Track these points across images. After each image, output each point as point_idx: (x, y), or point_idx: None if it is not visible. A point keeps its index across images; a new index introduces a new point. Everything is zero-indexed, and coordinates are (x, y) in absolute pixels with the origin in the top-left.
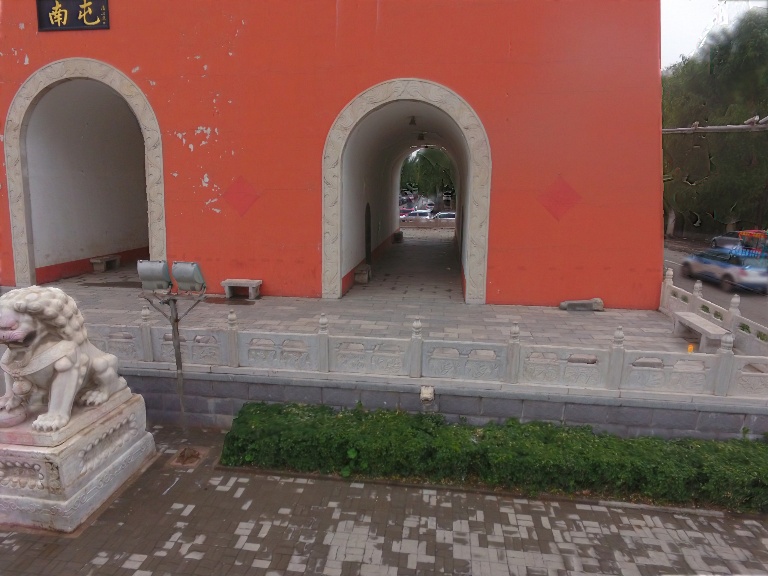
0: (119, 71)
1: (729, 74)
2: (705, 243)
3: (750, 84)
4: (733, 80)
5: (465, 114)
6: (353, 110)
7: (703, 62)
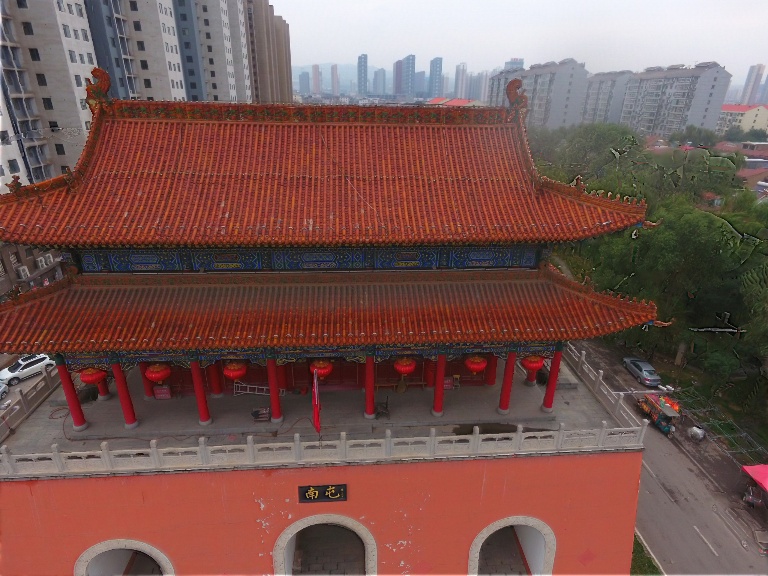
0: (352, 519)
1: (645, 270)
2: (617, 350)
3: (657, 277)
4: (647, 273)
5: (545, 529)
6: (488, 530)
7: (628, 250)
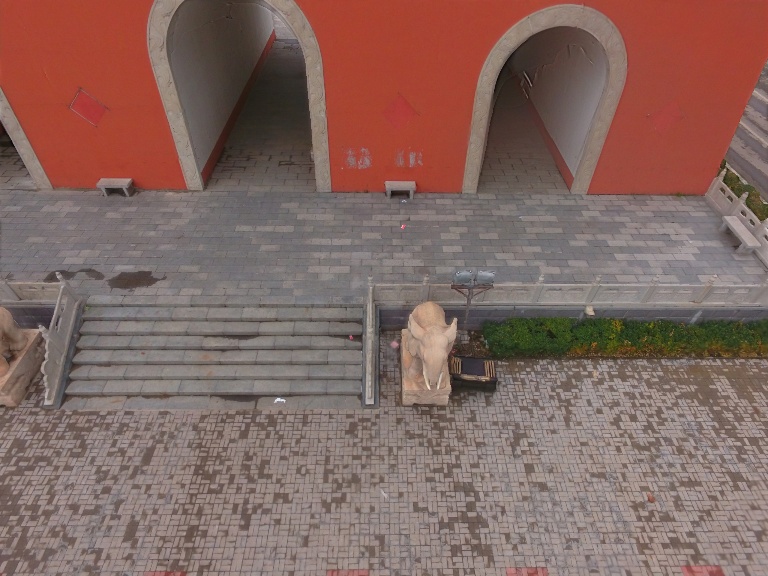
0: None
1: None
2: None
3: None
4: None
5: None
6: None
7: None
